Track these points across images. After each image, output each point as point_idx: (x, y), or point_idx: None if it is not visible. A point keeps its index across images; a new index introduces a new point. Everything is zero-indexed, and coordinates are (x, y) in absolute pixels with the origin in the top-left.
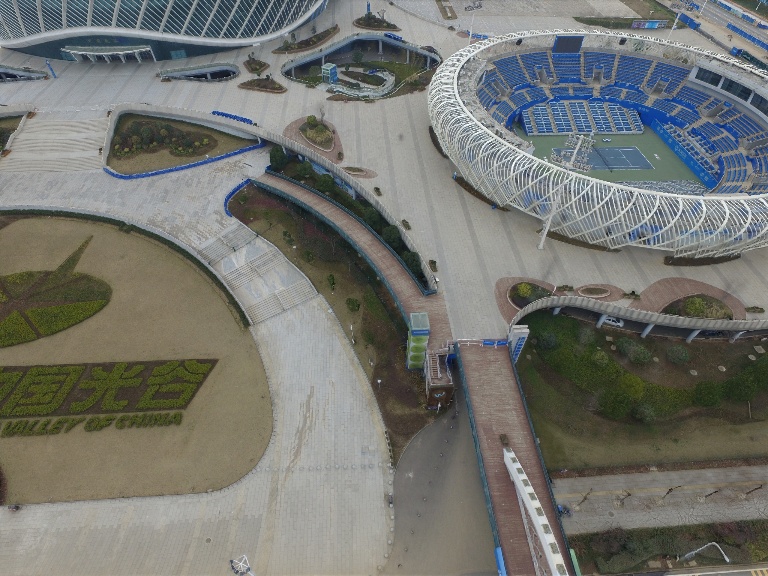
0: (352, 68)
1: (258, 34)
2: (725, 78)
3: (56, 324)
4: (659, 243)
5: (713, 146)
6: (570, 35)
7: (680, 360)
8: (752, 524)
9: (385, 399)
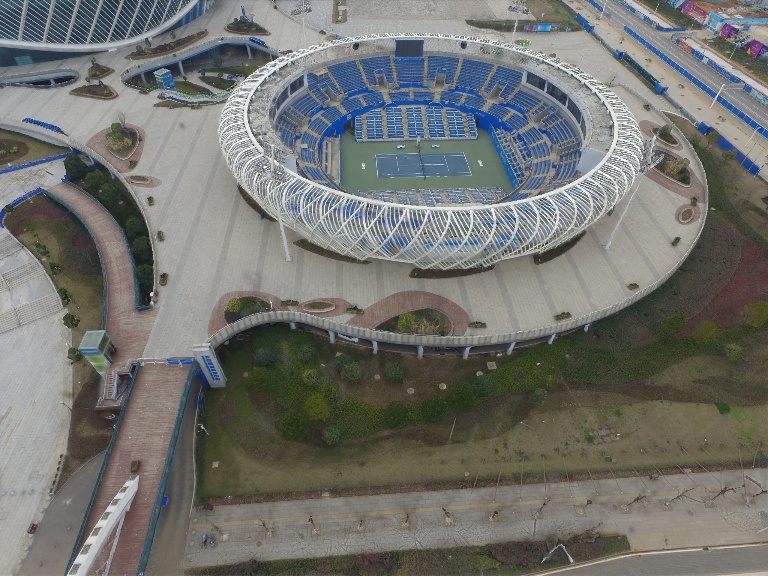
0: (213, 73)
1: (113, 39)
2: (548, 82)
3: None
4: (392, 255)
5: (530, 152)
6: (409, 39)
7: (390, 378)
8: (402, 555)
9: (77, 420)
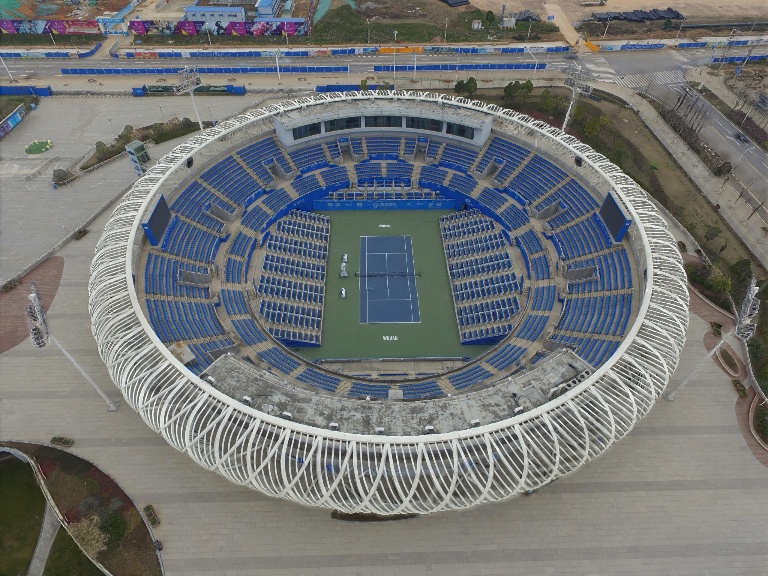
0: None
1: None
2: (325, 122)
3: None
4: None
5: (398, 179)
6: (152, 208)
7: None
8: None
9: None
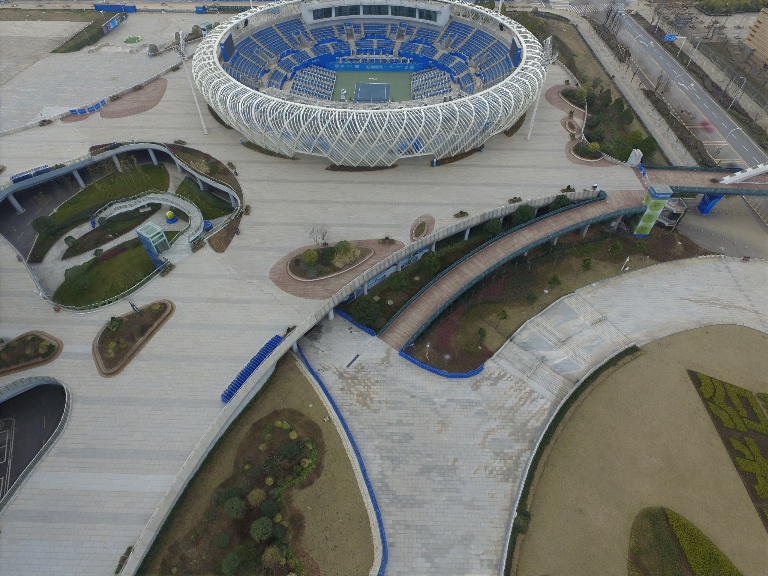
0: (57, 245)
1: None
2: (335, 8)
3: (730, 574)
4: None
5: (384, 50)
6: (225, 38)
7: None
8: None
9: (675, 253)
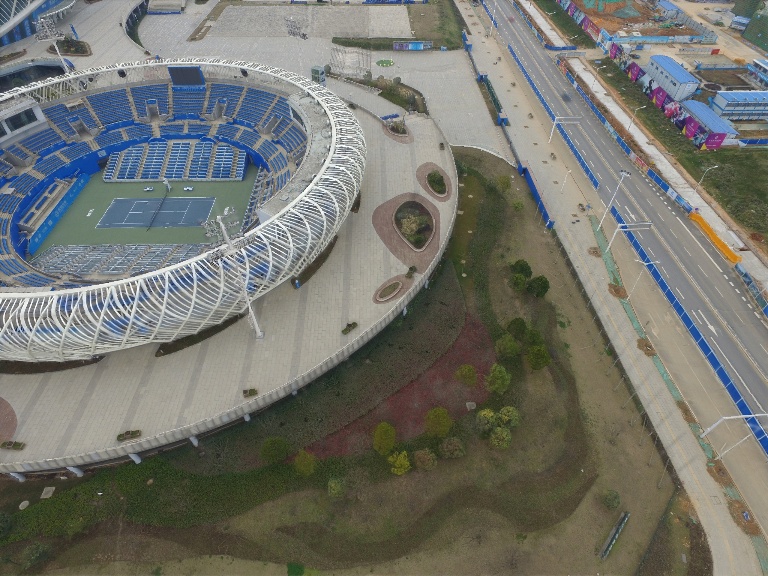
0: None
1: None
2: None
3: None
4: None
5: None
6: (182, 65)
7: None
8: None
9: None
